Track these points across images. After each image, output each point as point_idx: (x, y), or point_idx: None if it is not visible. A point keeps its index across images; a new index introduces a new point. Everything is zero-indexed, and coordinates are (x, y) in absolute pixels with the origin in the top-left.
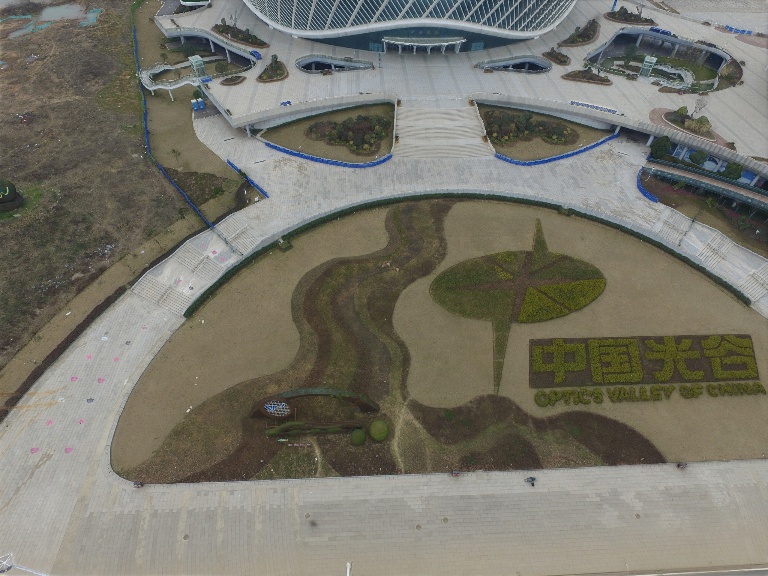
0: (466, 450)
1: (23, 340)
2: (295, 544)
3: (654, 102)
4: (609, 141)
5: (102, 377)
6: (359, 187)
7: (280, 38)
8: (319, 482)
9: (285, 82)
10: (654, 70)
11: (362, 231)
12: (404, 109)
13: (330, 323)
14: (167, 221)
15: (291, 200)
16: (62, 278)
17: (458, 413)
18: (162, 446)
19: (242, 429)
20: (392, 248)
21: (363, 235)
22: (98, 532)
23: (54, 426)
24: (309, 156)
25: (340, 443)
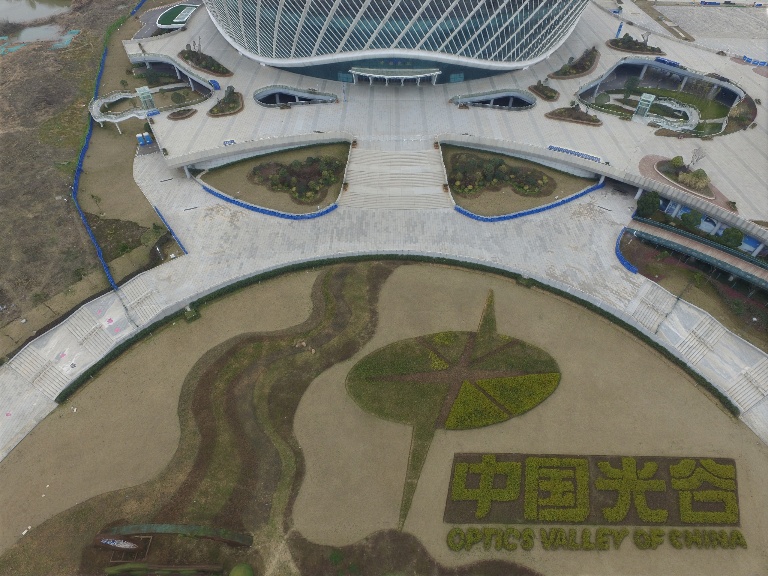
0: None
1: None
2: None
3: (647, 148)
4: (591, 192)
5: None
6: (291, 244)
7: (247, 66)
8: None
9: (237, 117)
10: (657, 106)
11: (283, 299)
12: (359, 151)
13: (219, 419)
14: (70, 279)
15: (211, 258)
16: None
17: (347, 555)
18: None
19: (80, 563)
20: (313, 323)
21: (283, 304)
22: None
23: None
24: (245, 204)
25: None
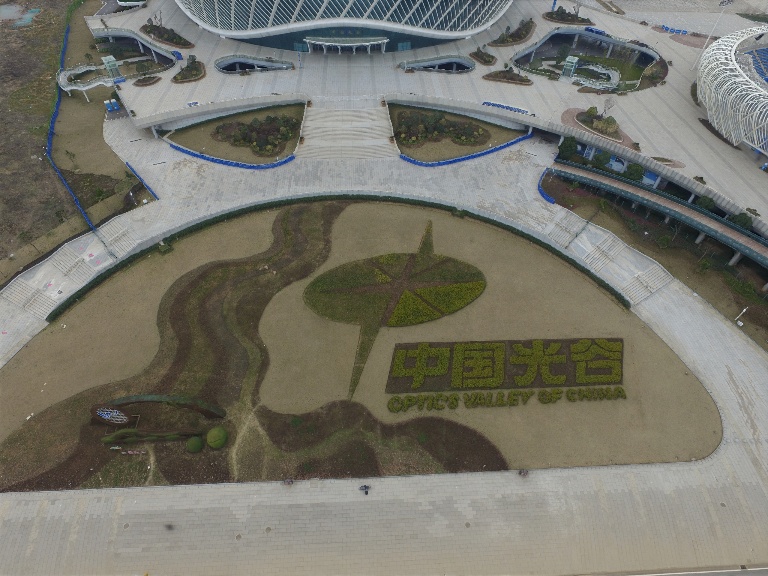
0: (306, 457)
1: None
2: (106, 555)
3: (570, 102)
4: (521, 142)
5: None
6: (253, 189)
7: (207, 38)
8: (146, 491)
9: (200, 83)
10: (585, 70)
11: (247, 233)
12: (314, 110)
13: (194, 327)
14: (51, 224)
15: (181, 202)
16: None
17: (305, 419)
18: None
19: (79, 436)
20: (274, 251)
21: (247, 237)
22: None
23: None
24: (210, 157)
25: (177, 451)
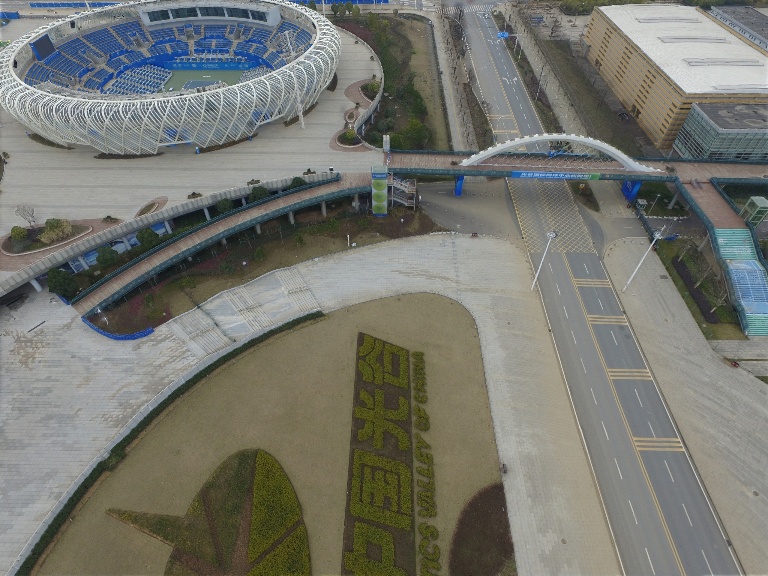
0: None
1: None
2: None
3: None
4: None
5: None
6: None
7: None
8: None
9: None
10: None
11: None
12: None
13: None
14: None
15: None
16: None
17: None
18: None
19: None
20: None
21: None
22: None
23: None
24: None
25: None
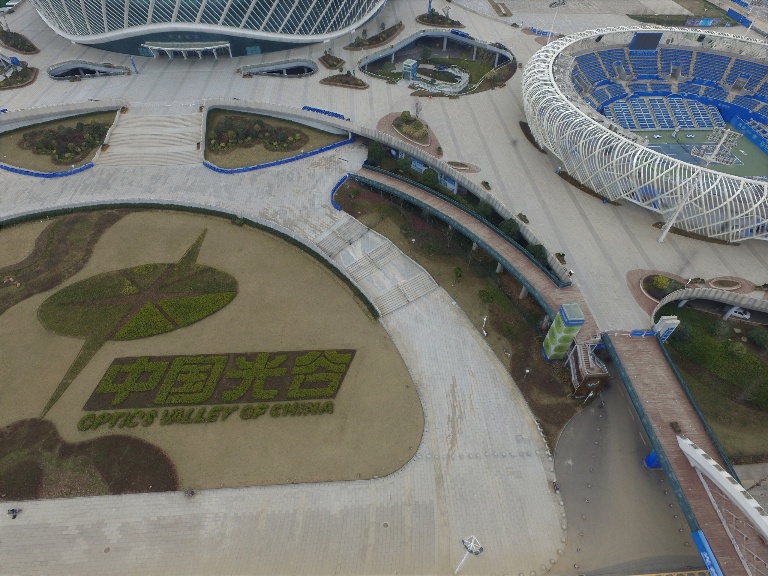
0: None
1: None
2: None
3: (396, 106)
4: (339, 147)
5: None
6: (34, 198)
7: (57, 44)
8: None
9: (24, 89)
10: (443, 73)
11: (9, 244)
12: (127, 116)
13: None
14: None
15: None
16: None
17: None
18: None
19: None
20: (27, 262)
21: (7, 248)
22: None
23: None
24: (4, 166)
25: None
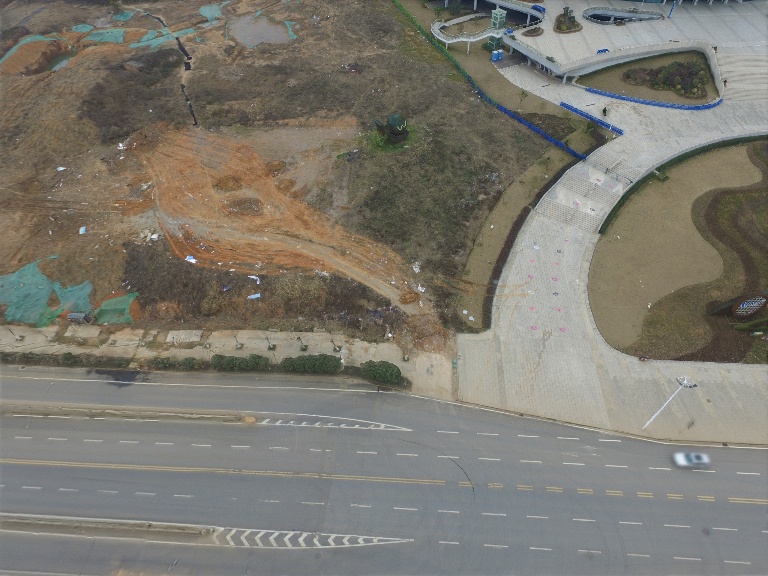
0: None
1: (469, 245)
2: None
3: None
4: None
5: (554, 277)
6: (707, 127)
7: None
8: None
9: (584, 33)
10: None
11: (730, 165)
12: (721, 55)
13: (742, 243)
14: (535, 154)
15: (646, 137)
16: (471, 198)
17: None
18: (643, 332)
19: (708, 323)
20: None
21: (733, 169)
22: (629, 391)
23: (538, 311)
24: None
25: None
